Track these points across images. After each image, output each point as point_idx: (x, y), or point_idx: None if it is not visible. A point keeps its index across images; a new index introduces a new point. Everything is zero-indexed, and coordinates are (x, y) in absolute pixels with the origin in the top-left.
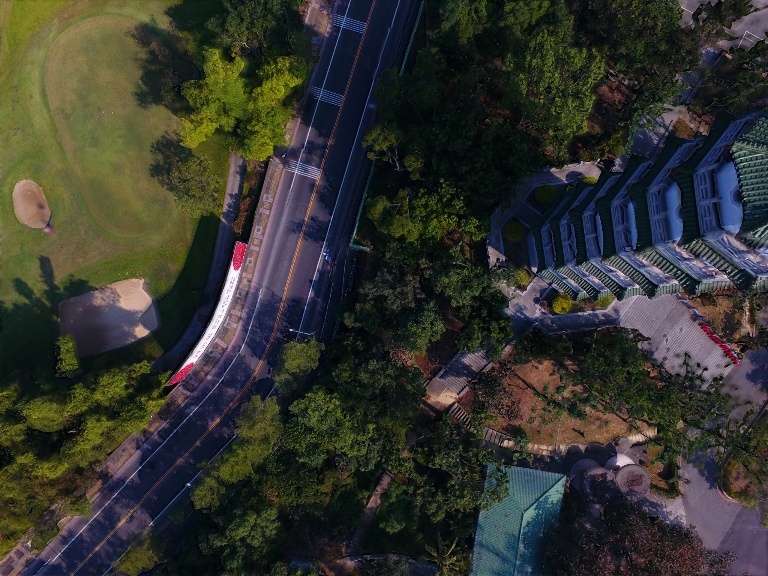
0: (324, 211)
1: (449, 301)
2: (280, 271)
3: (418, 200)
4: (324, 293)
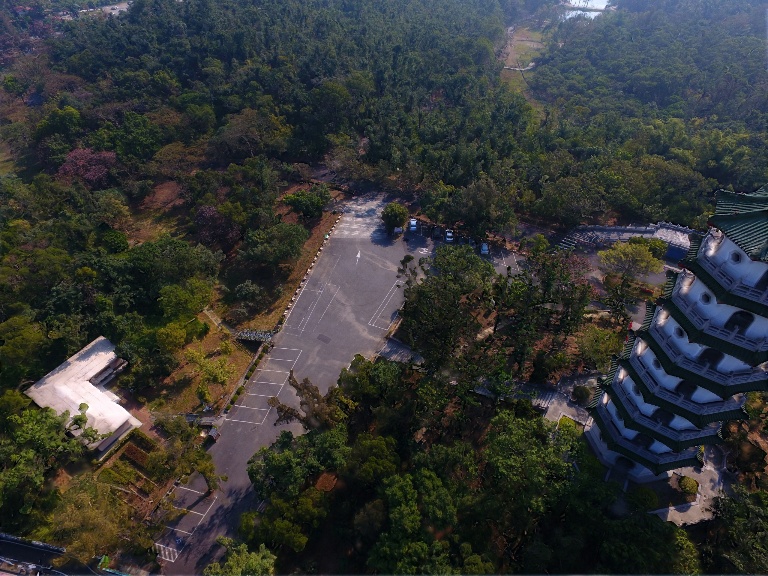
0: None
1: None
2: None
3: None
4: None
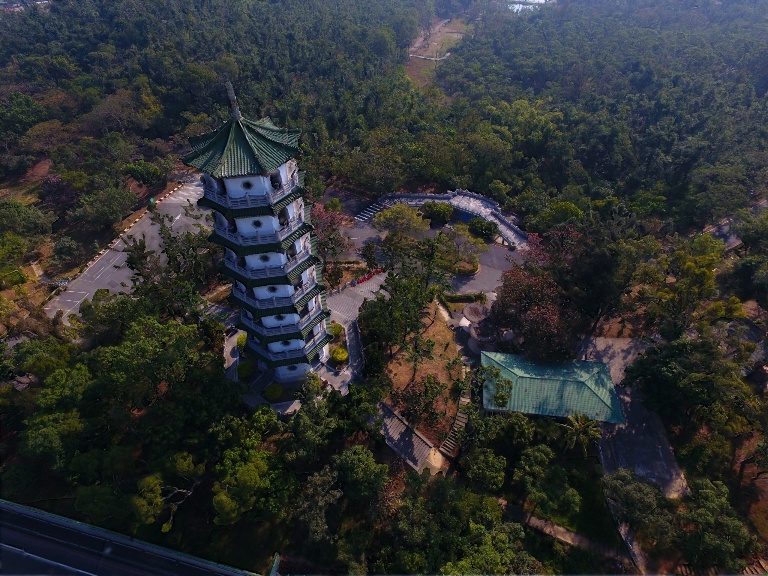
0: None
1: (338, 455)
2: None
3: (227, 468)
4: None
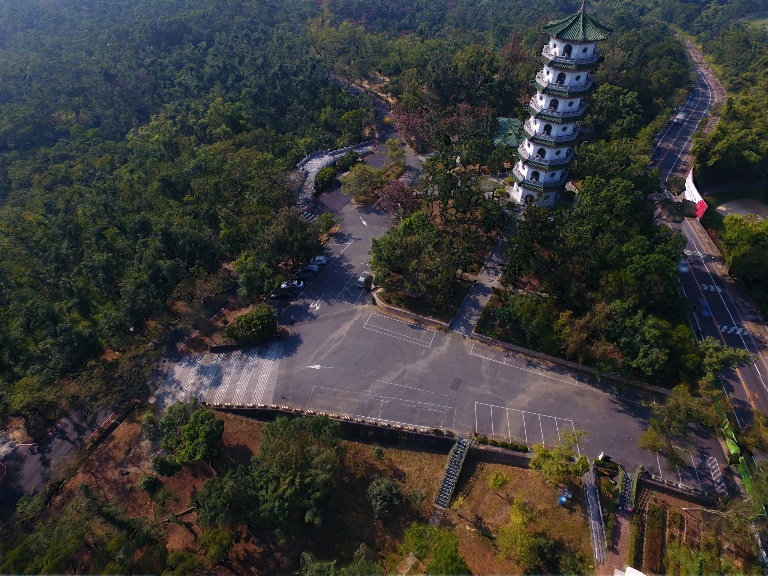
0: None
1: None
2: None
3: None
4: None
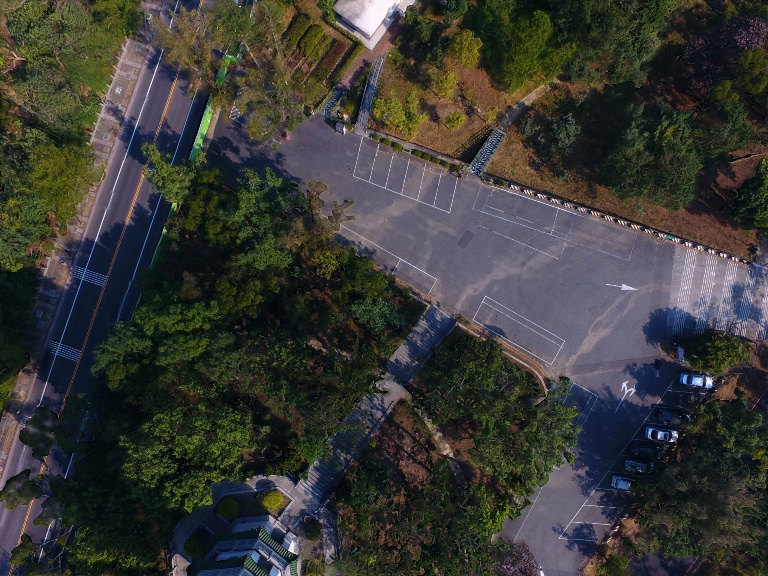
0: (58, 469)
1: None
2: (12, 529)
3: (77, 533)
4: (54, 554)
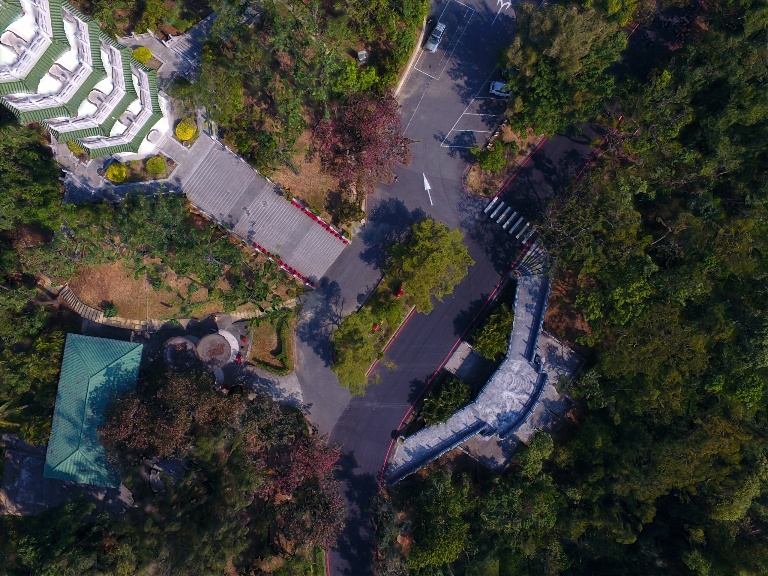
0: None
1: None
2: None
3: None
4: None
